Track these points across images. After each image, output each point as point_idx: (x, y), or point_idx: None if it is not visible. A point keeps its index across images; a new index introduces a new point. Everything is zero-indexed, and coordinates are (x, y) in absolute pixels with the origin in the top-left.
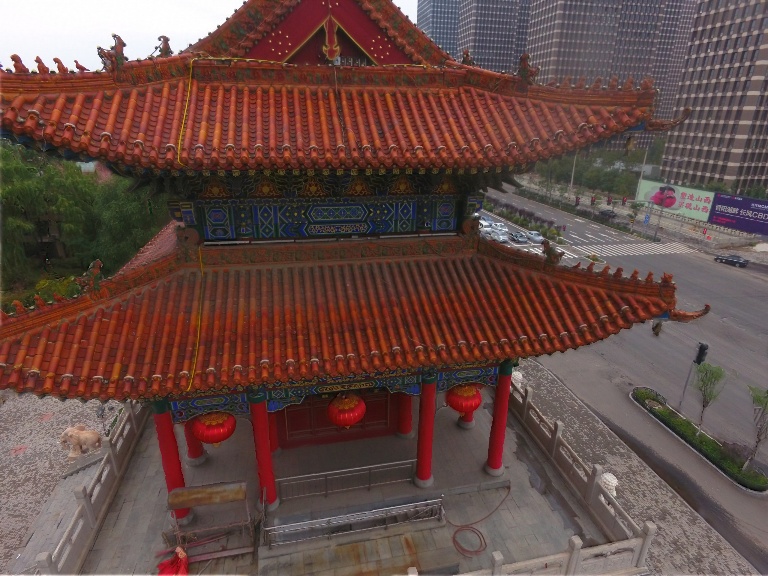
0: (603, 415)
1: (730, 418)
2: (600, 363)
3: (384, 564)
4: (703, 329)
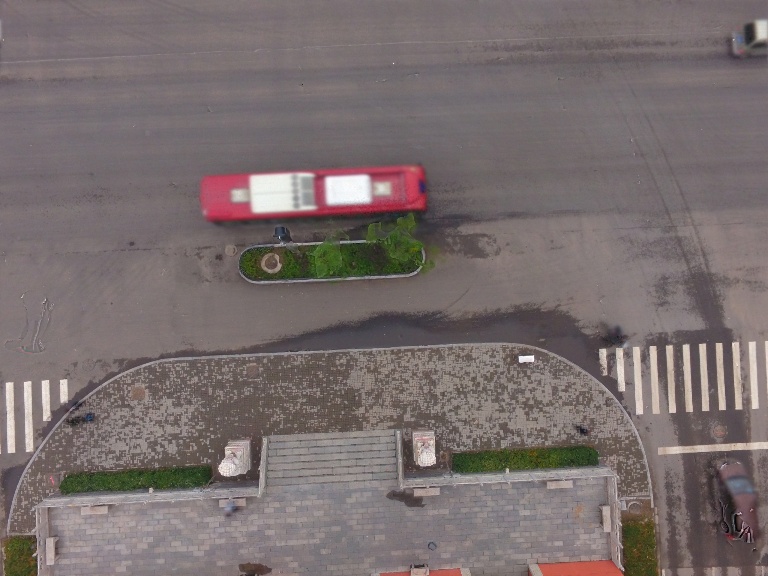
0: (278, 341)
1: (311, 183)
2: (158, 266)
3: None
4: (75, 1)
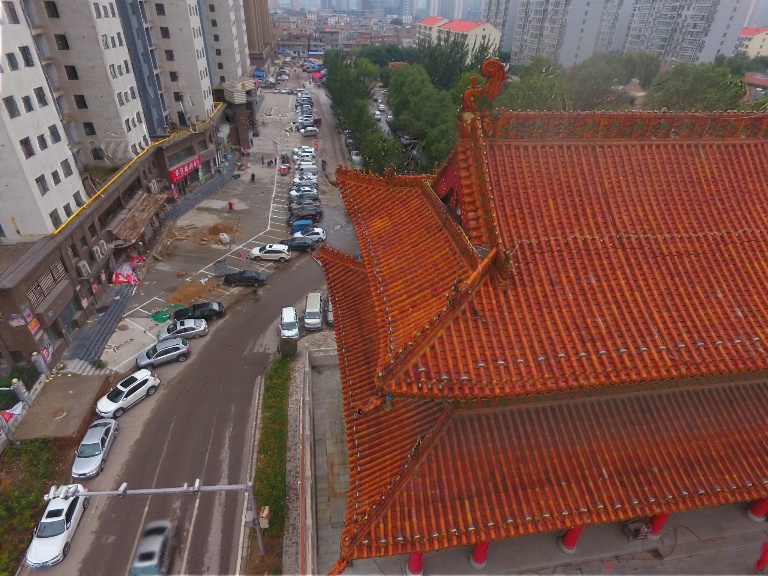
0: None
1: None
2: None
3: (336, 477)
4: None
